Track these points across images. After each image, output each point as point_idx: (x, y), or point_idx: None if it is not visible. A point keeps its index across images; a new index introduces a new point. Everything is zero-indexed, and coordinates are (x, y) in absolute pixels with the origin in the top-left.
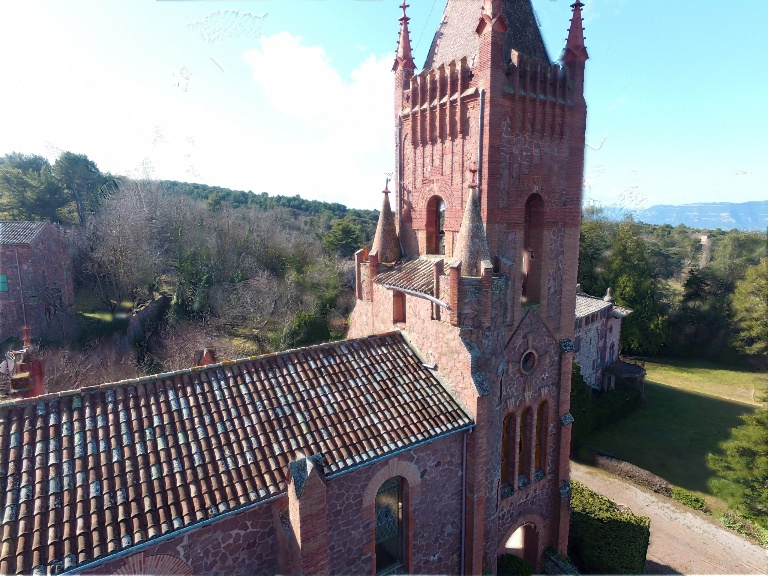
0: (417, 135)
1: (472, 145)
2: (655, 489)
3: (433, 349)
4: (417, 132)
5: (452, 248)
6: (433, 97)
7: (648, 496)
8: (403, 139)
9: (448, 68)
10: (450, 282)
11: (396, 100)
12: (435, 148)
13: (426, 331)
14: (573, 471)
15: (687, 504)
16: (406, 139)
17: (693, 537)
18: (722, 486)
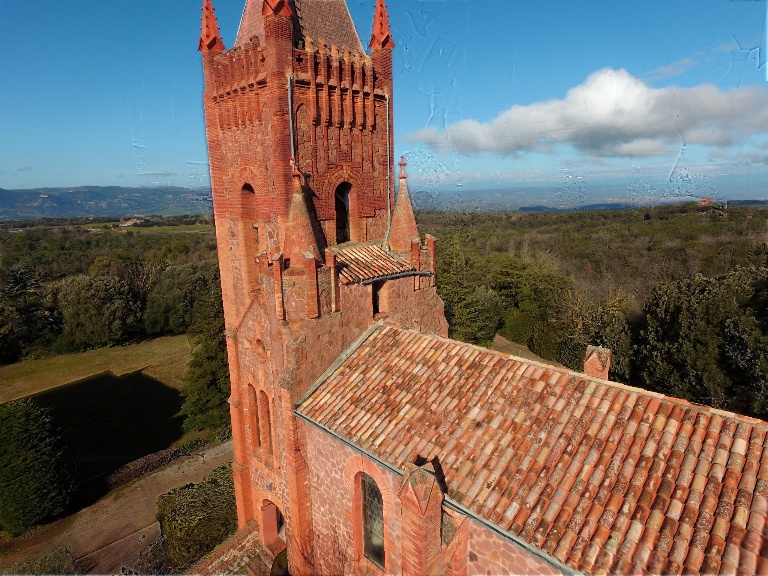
0: (319, 111)
1: (380, 140)
2: (168, 460)
3: (417, 316)
4: (319, 108)
5: (366, 233)
6: (340, 78)
7: (171, 469)
8: (296, 109)
9: (360, 59)
10: (433, 253)
11: (281, 52)
12: (342, 132)
13: (410, 305)
14: (107, 510)
15: (192, 450)
16: (299, 110)
17: (227, 459)
18: (208, 417)
